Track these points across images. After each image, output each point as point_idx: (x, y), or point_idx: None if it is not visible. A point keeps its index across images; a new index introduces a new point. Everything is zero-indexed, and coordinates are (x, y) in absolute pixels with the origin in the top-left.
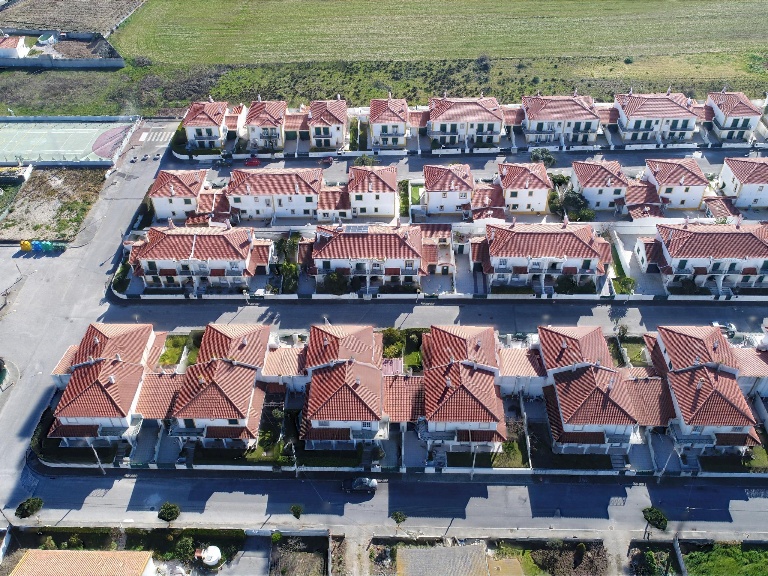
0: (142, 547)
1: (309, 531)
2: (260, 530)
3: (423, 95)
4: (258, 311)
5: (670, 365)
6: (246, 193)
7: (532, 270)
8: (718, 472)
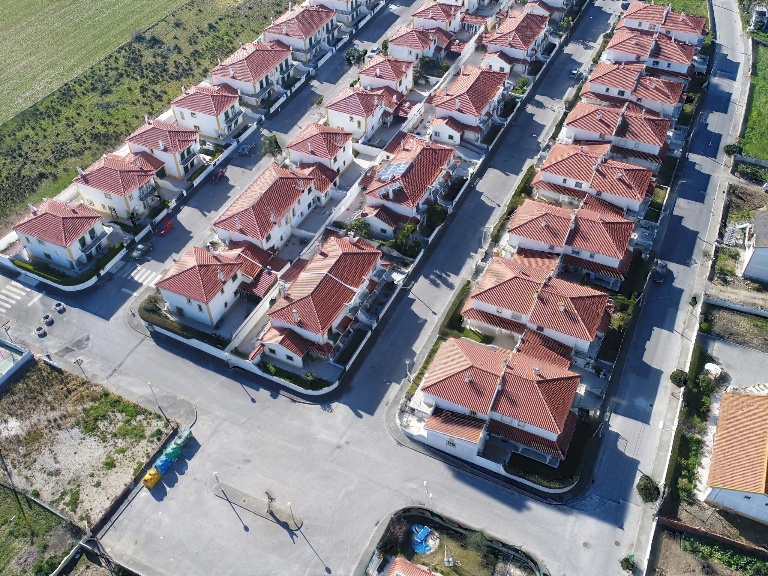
0: (696, 416)
1: None
2: None
3: (160, 87)
4: (424, 284)
5: (620, 93)
6: (273, 224)
7: None
8: None
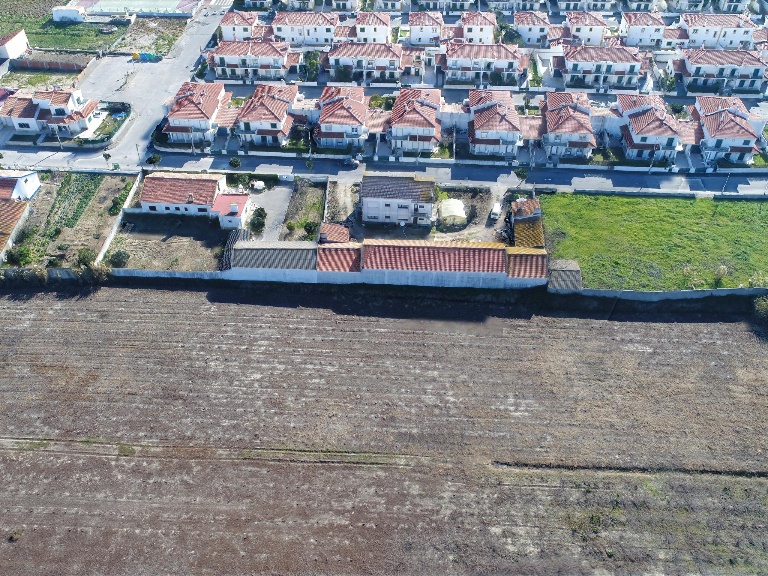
0: None
1: (317, 178)
2: (288, 176)
3: None
4: None
5: None
6: (286, 24)
7: (474, 68)
8: (569, 164)
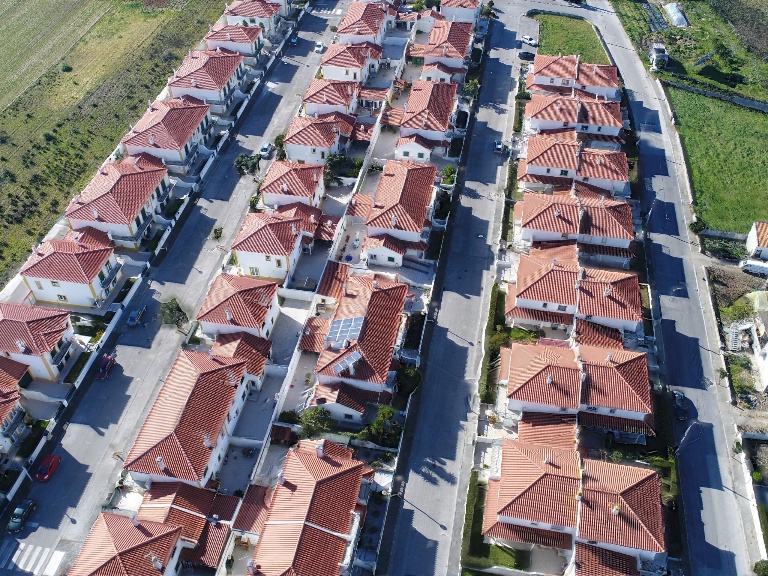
0: None
1: None
2: None
3: None
4: (417, 483)
5: (563, 173)
6: (208, 451)
7: None
8: None
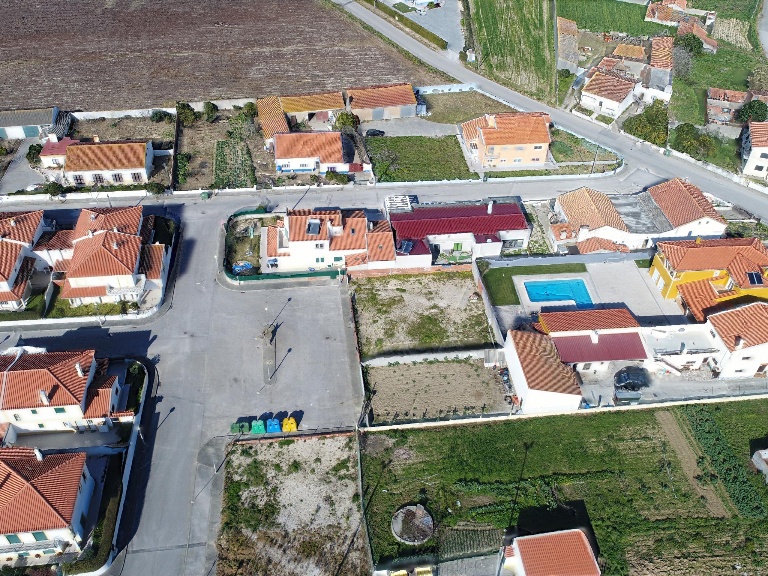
0: None
1: None
2: None
3: None
4: None
5: None
6: None
7: None
8: None
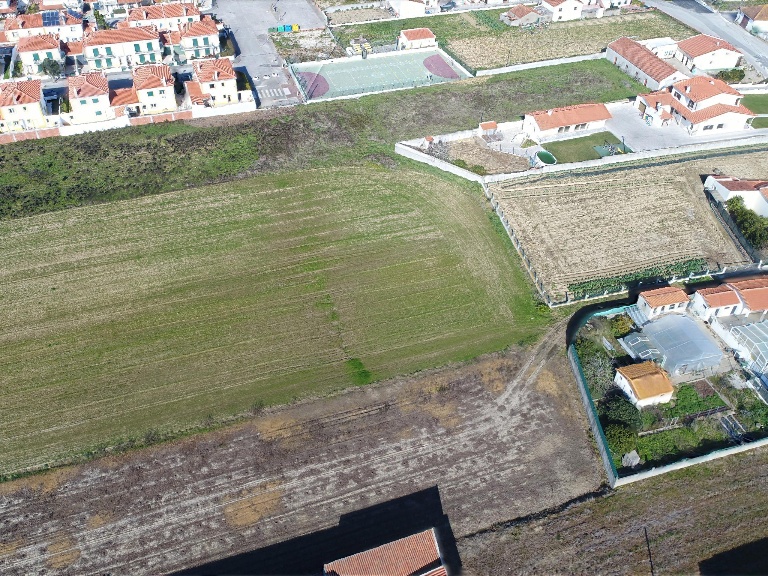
0: None
1: None
2: None
3: None
4: None
5: None
6: None
7: None
8: None
